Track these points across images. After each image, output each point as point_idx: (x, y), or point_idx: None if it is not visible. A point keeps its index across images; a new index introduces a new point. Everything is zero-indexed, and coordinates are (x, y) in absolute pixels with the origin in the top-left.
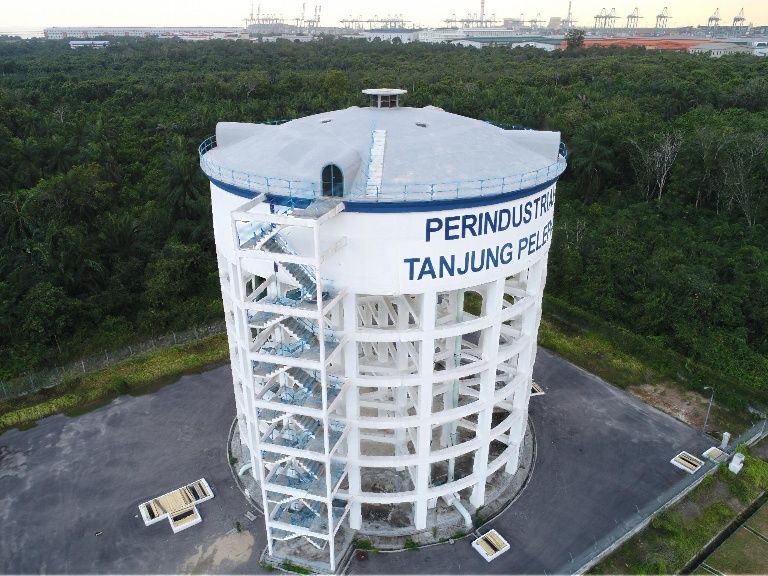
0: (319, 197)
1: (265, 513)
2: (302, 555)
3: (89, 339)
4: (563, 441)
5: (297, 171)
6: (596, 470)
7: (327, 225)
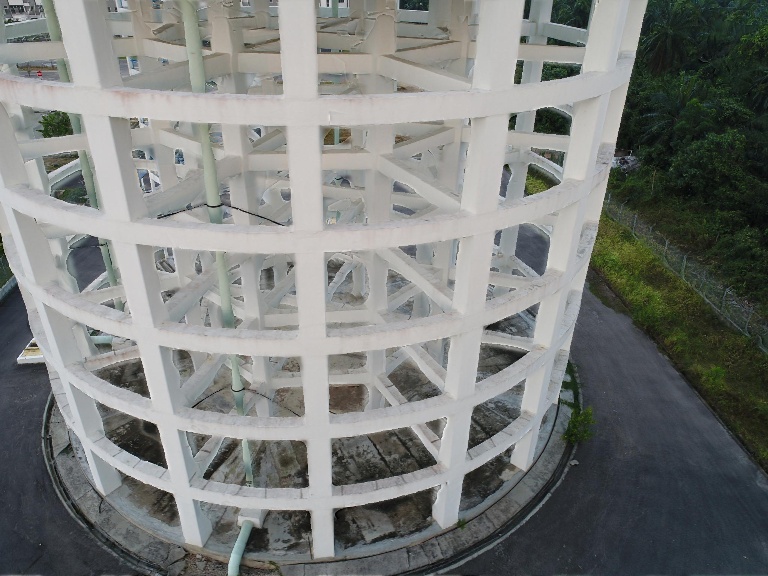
0: None
1: None
2: None
3: (688, 212)
4: (19, 567)
5: None
6: None
7: None
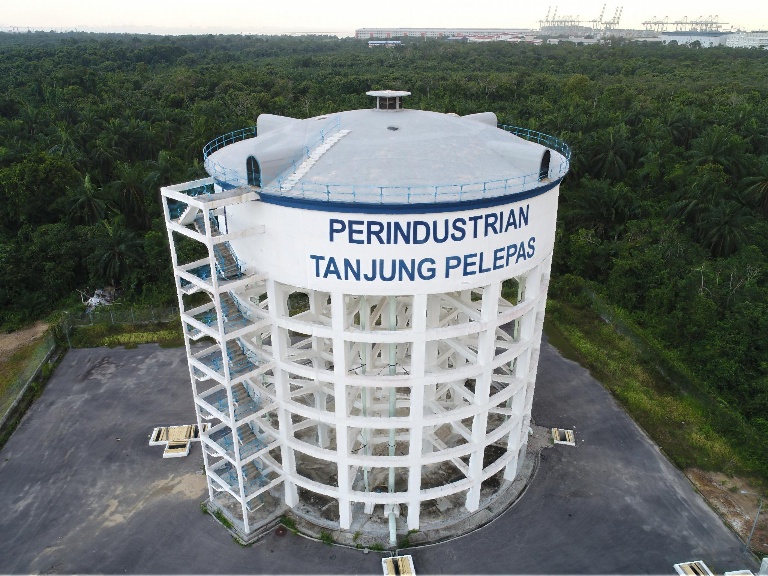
0: (244, 185)
1: (204, 461)
2: (233, 510)
3: None
4: (557, 499)
5: None
6: (571, 541)
7: (252, 212)
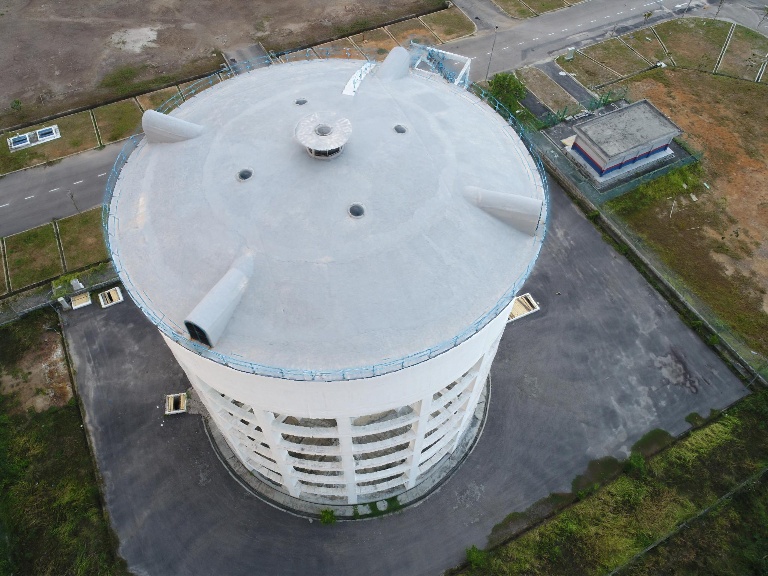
0: (410, 71)
1: None
2: None
3: None
4: None
5: (429, 88)
6: None
7: None
